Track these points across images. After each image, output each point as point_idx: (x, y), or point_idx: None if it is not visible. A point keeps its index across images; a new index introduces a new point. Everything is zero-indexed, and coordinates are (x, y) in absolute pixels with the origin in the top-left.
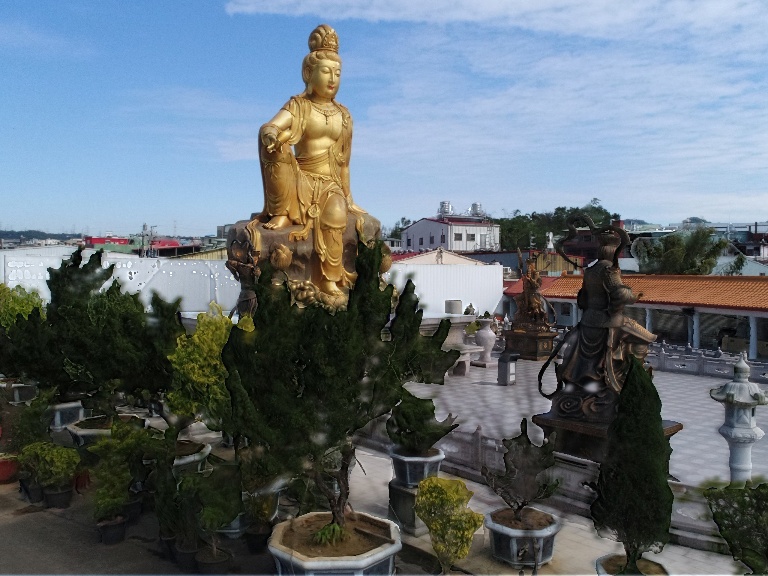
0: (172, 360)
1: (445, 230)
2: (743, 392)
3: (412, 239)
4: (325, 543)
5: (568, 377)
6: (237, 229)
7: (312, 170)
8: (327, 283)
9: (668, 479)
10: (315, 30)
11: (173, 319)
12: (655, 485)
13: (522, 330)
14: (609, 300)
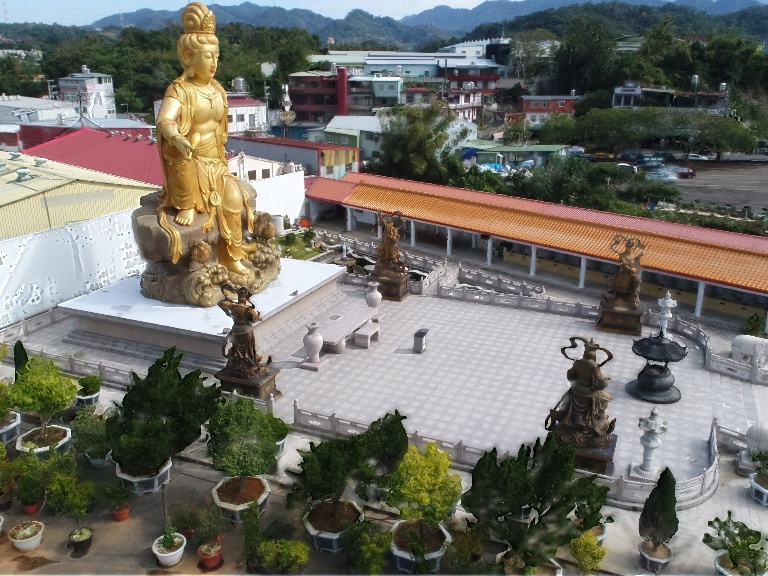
0: (407, 493)
1: None
2: (657, 426)
3: None
4: None
5: (567, 423)
6: (151, 227)
7: (203, 155)
8: (234, 263)
9: (611, 465)
10: (190, 9)
11: None
12: (675, 521)
13: (386, 277)
14: (594, 383)
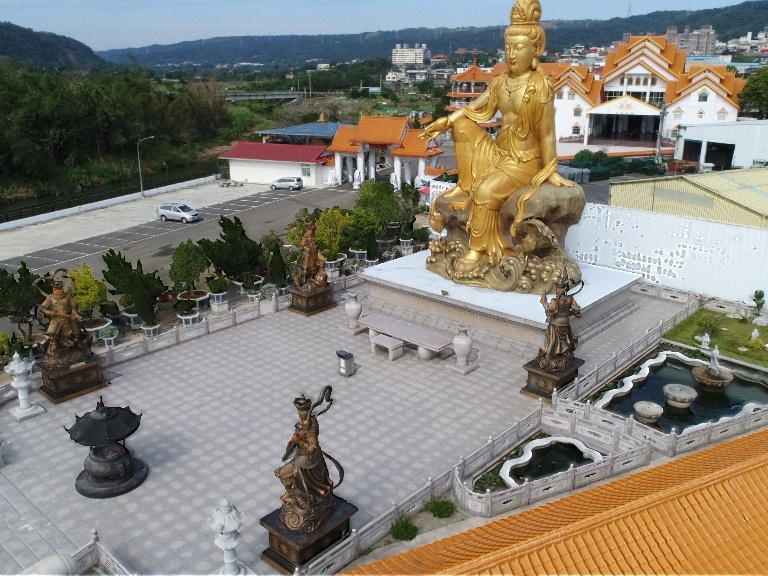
0: None
1: None
2: None
3: None
4: None
5: None
6: None
7: None
8: None
9: None
10: None
11: (114, 263)
12: None
13: None
14: None
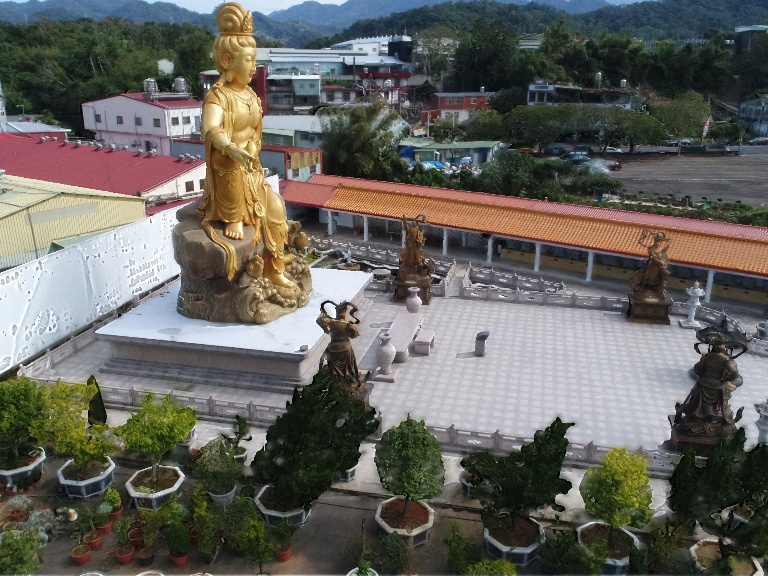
0: None
1: (160, 114)
2: None
3: (103, 115)
4: (734, 568)
5: (698, 415)
6: (204, 243)
7: None
8: (279, 276)
9: None
10: (228, 9)
11: None
12: None
13: (412, 281)
14: (724, 375)
